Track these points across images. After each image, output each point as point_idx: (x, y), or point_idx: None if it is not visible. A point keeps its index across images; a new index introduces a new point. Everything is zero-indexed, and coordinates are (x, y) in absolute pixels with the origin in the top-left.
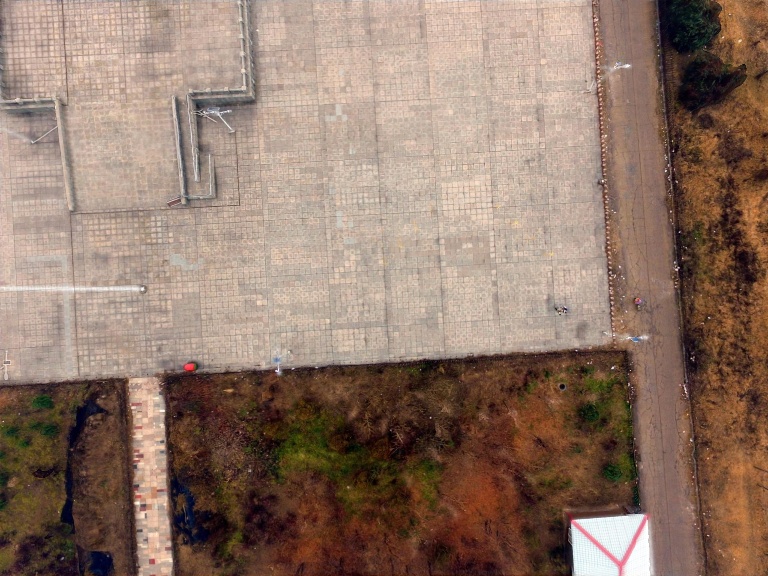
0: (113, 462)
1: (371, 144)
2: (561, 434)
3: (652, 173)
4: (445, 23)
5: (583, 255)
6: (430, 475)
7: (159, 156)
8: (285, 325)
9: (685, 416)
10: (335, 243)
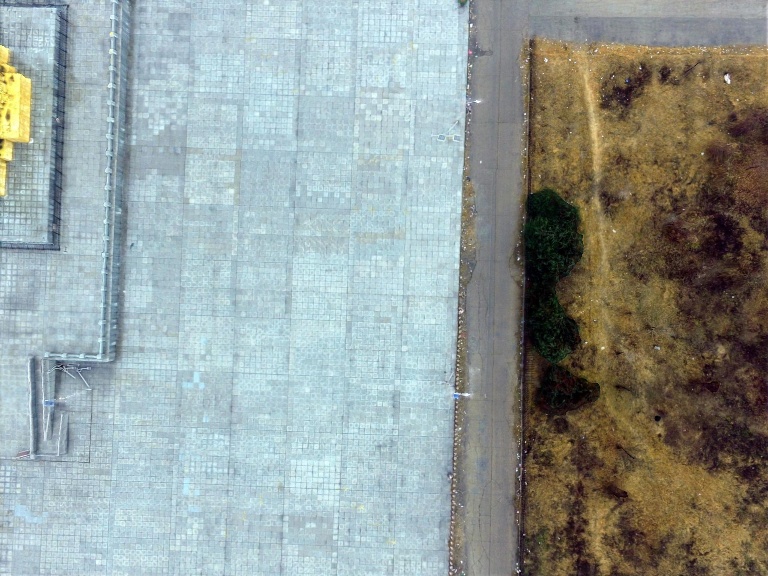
0: None
1: (225, 414)
2: None
3: (503, 471)
4: (310, 301)
5: (426, 547)
6: None
7: (13, 409)
8: None
9: None
10: (179, 510)
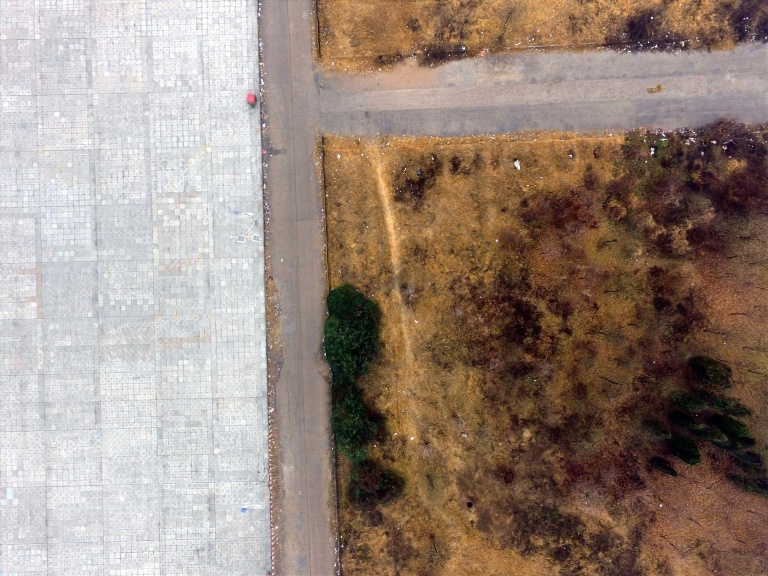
0: None
1: (41, 529)
2: None
3: (322, 566)
4: (120, 410)
5: None
6: None
7: None
8: None
9: None
10: None
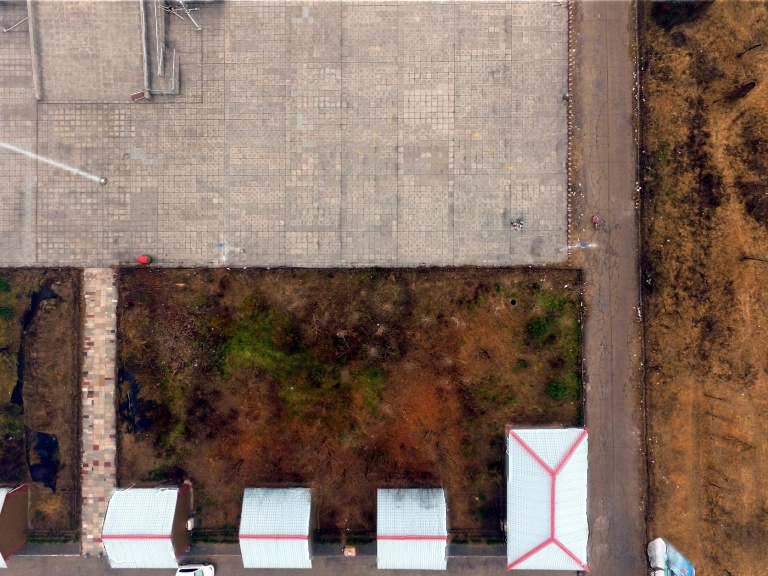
0: (64, 348)
1: (336, 48)
2: (509, 349)
3: (619, 91)
4: None
5: (543, 170)
6: (374, 382)
7: (125, 49)
8: (240, 224)
9: (637, 340)
10: (294, 145)
